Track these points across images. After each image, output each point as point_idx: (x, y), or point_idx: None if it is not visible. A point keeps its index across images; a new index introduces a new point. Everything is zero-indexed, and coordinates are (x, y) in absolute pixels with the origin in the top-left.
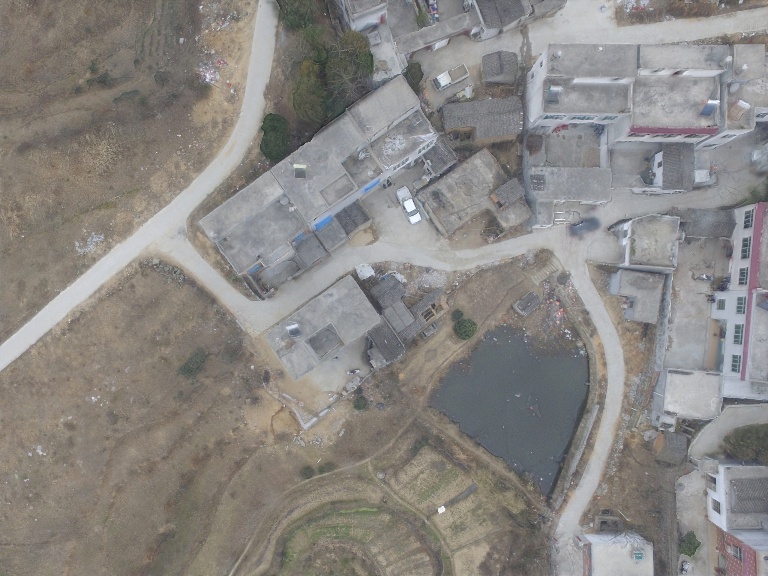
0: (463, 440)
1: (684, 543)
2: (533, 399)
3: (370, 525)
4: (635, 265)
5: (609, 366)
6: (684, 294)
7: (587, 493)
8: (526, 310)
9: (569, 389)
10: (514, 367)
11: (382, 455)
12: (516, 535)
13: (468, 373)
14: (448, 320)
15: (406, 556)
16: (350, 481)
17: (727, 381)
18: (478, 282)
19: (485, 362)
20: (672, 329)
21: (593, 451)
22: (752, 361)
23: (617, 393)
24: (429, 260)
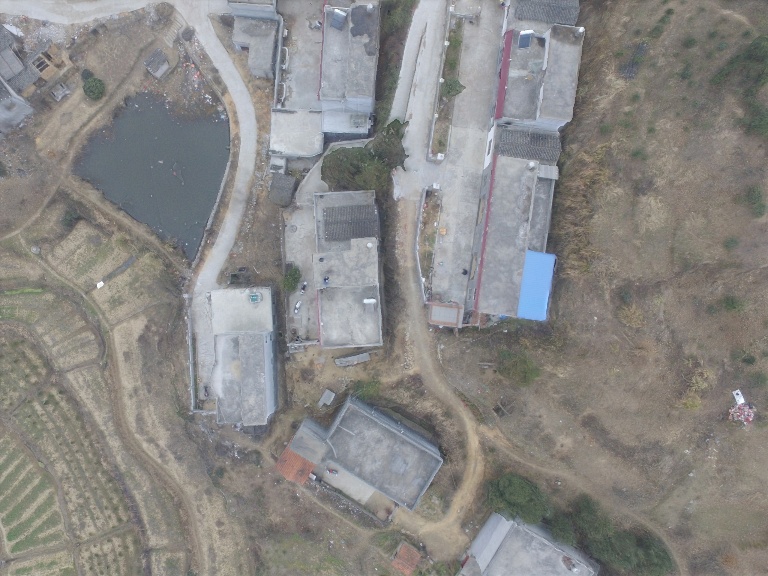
0: (104, 205)
1: (286, 276)
2: (180, 167)
3: (35, 306)
4: (233, 3)
5: (241, 124)
6: (302, 44)
7: (224, 251)
8: (151, 66)
9: (216, 157)
10: (157, 133)
11: (31, 227)
12: (173, 307)
13: (111, 140)
14: (80, 82)
15: (72, 336)
16: (8, 259)
17: (326, 116)
18: (107, 42)
19: (128, 129)
20: (292, 79)
21: (228, 209)
22: (328, 81)
23: (250, 151)
24: (46, 13)
